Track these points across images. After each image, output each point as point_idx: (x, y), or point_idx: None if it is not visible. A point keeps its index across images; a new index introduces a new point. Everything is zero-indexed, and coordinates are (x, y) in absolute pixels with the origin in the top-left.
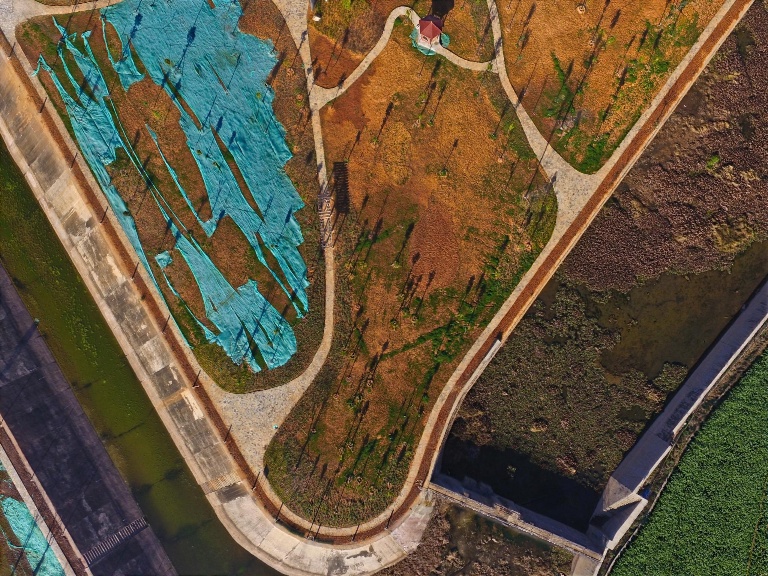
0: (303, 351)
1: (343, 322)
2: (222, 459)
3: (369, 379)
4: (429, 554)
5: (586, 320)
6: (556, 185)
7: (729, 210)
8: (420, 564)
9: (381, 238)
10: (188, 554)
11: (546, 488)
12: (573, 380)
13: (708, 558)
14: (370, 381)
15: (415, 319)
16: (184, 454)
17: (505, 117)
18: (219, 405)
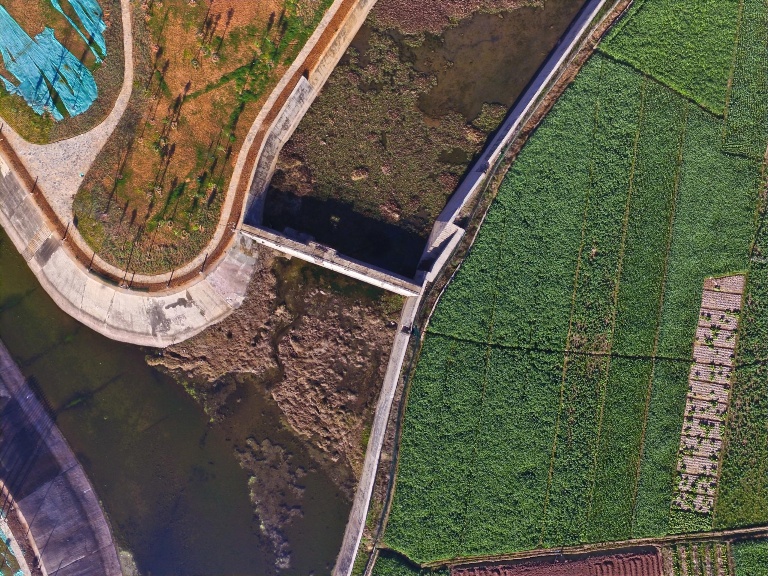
0: (104, 96)
1: (143, 64)
2: (32, 214)
3: (173, 121)
4: (256, 308)
5: (401, 64)
6: None
7: None
8: (247, 319)
9: None
10: (14, 325)
11: (370, 236)
12: (391, 126)
13: (531, 287)
14: (174, 123)
15: (216, 58)
16: (3, 223)
17: None
18: (24, 157)
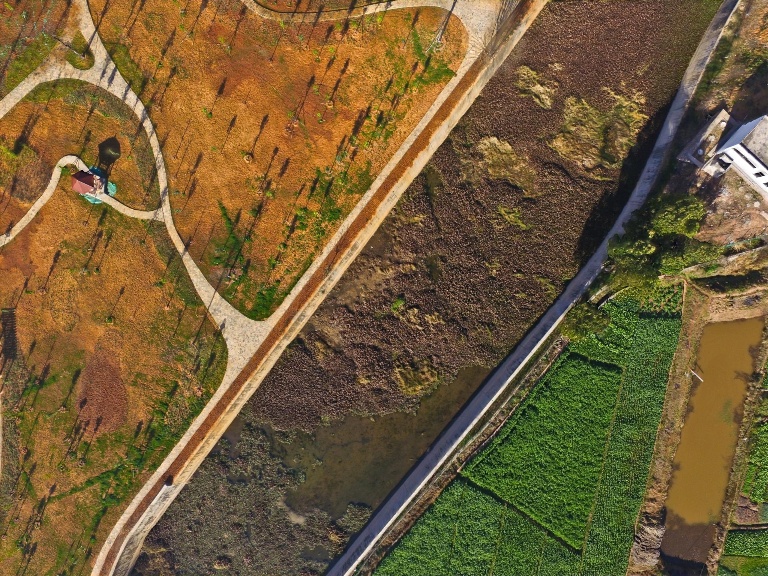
0: None
1: (10, 465)
2: None
3: (37, 521)
4: None
5: (270, 459)
6: (225, 332)
7: (415, 352)
8: None
9: (48, 383)
10: None
11: None
12: (257, 519)
13: None
14: (38, 523)
15: (82, 463)
16: None
17: (171, 265)
18: None
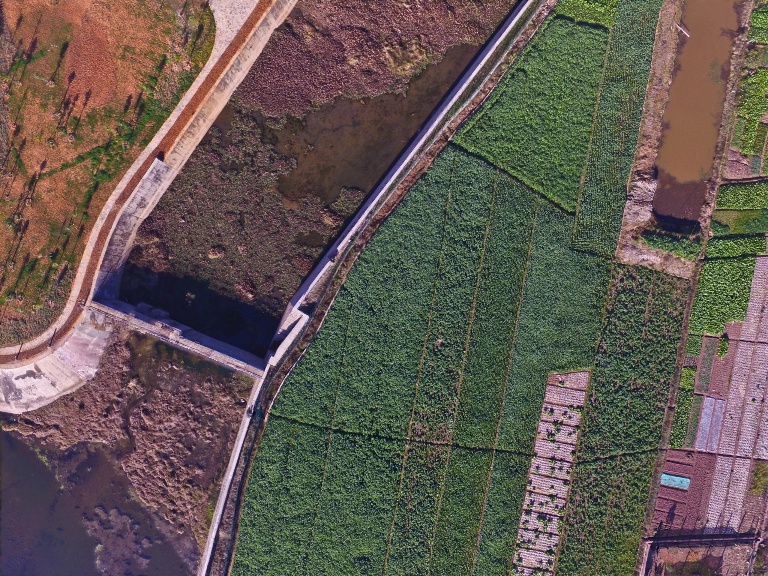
0: None
1: None
2: None
3: (28, 198)
4: (108, 381)
5: (262, 146)
6: (212, 3)
7: (403, 33)
8: (99, 390)
9: (36, 58)
10: None
11: (224, 314)
12: (250, 206)
13: (374, 375)
14: (29, 200)
15: (72, 138)
16: None
17: None
18: None
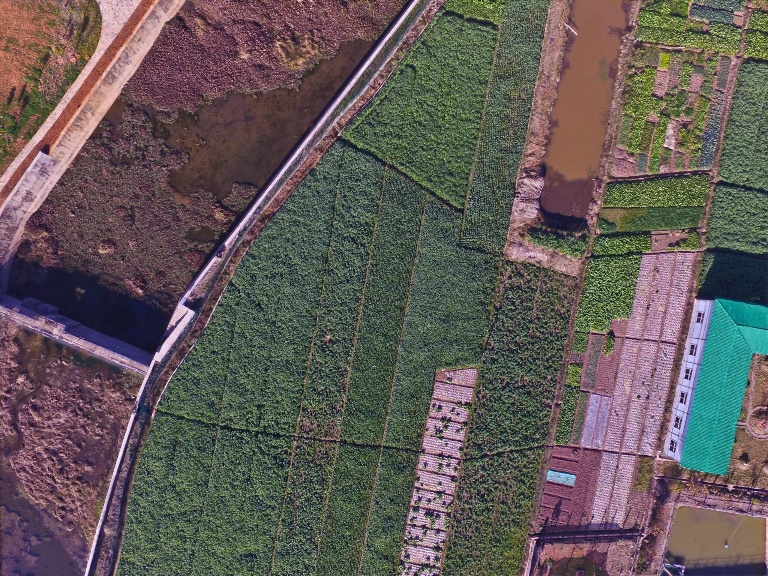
0: None
1: None
2: None
3: None
4: None
5: (153, 140)
6: None
7: (295, 27)
8: None
9: None
10: None
11: (114, 309)
12: (141, 201)
13: (261, 371)
14: None
15: None
16: None
17: None
18: None
